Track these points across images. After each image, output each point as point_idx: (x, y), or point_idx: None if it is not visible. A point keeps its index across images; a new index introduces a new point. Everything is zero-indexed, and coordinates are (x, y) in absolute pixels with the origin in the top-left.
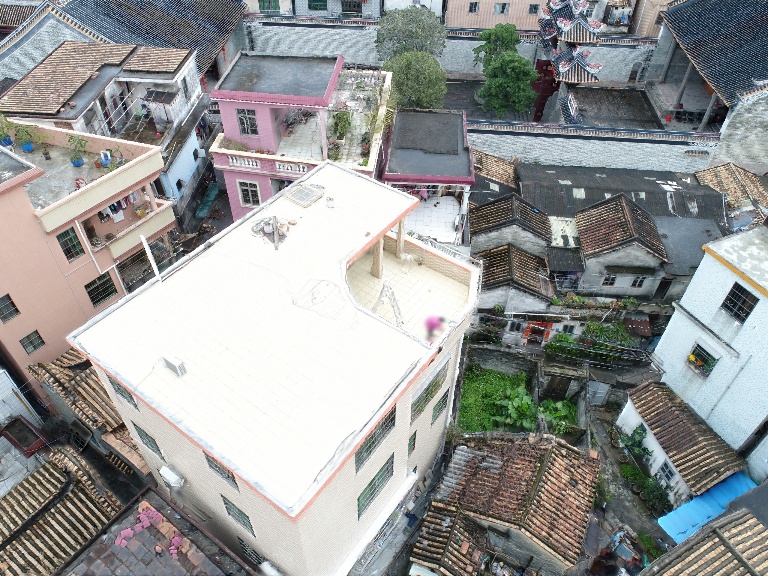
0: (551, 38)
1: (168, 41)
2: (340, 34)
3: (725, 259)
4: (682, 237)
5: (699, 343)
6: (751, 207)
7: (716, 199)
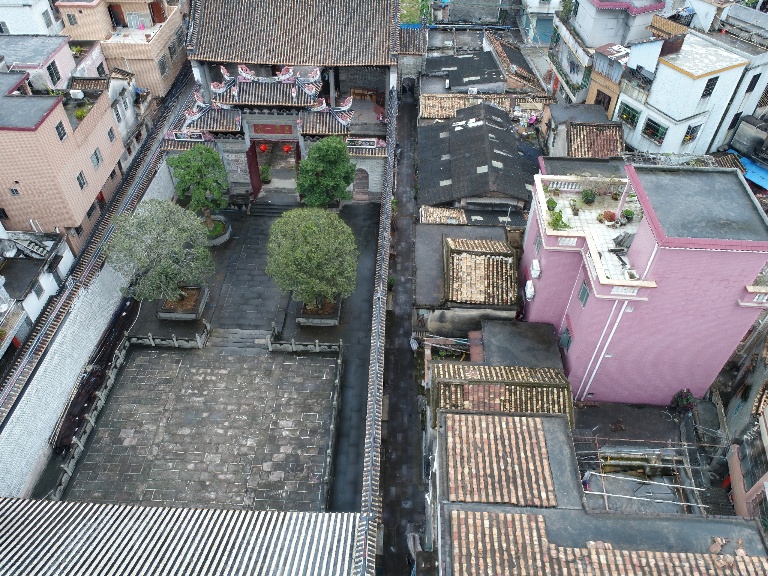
0: (240, 125)
1: (215, 575)
2: (55, 351)
3: (706, 73)
4: (577, 118)
5: (694, 126)
6: (479, 100)
7: (487, 107)
